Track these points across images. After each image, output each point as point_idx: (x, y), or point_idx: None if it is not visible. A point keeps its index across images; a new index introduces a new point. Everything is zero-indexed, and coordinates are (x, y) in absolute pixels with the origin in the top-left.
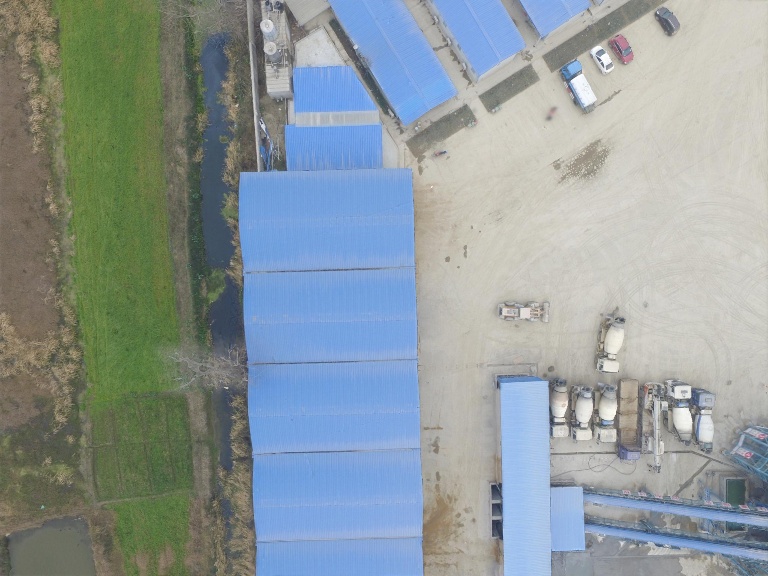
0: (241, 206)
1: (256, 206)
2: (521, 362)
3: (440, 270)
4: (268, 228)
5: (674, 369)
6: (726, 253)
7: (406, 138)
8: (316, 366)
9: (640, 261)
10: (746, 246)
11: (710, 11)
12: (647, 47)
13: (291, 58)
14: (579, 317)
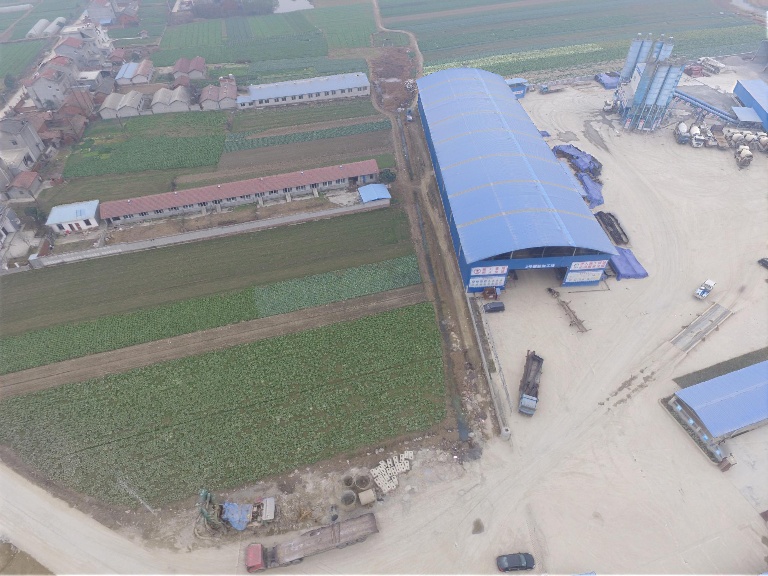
0: None
1: None
2: None
3: None
4: None
5: None
6: None
7: None
8: None
9: None
10: (670, 180)
11: None
12: None
13: None
14: (761, 170)
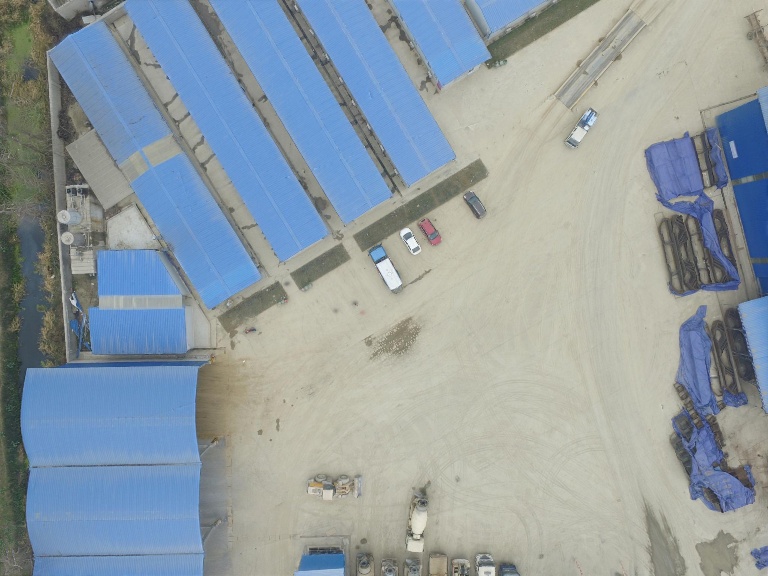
0: (24, 405)
1: (38, 406)
2: (334, 534)
3: (252, 443)
4: (50, 428)
5: (486, 542)
6: (537, 430)
7: (218, 313)
8: (102, 559)
9: (451, 436)
10: (557, 423)
11: (519, 194)
12: (457, 228)
13: (103, 234)
14: (391, 490)
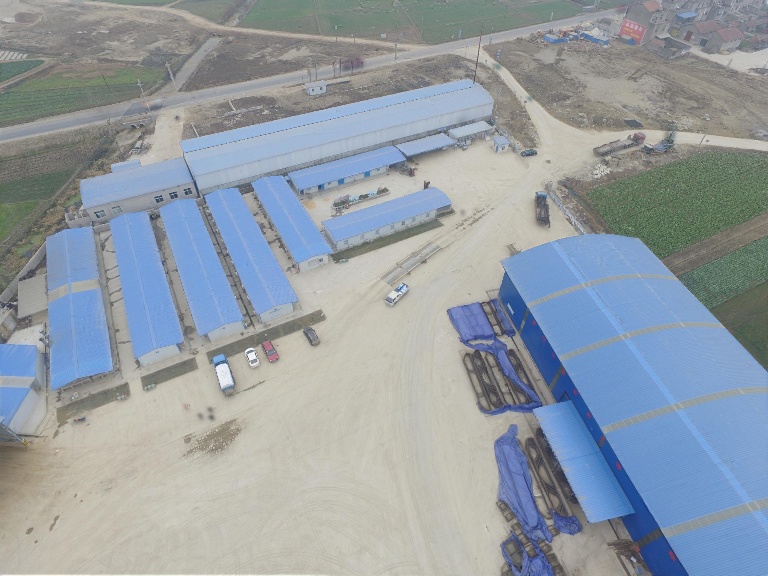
0: None
1: None
2: None
3: (13, 544)
4: None
5: None
6: (344, 549)
7: (59, 405)
8: None
9: (244, 551)
10: (367, 542)
11: (348, 332)
12: (294, 352)
13: (4, 341)
14: None
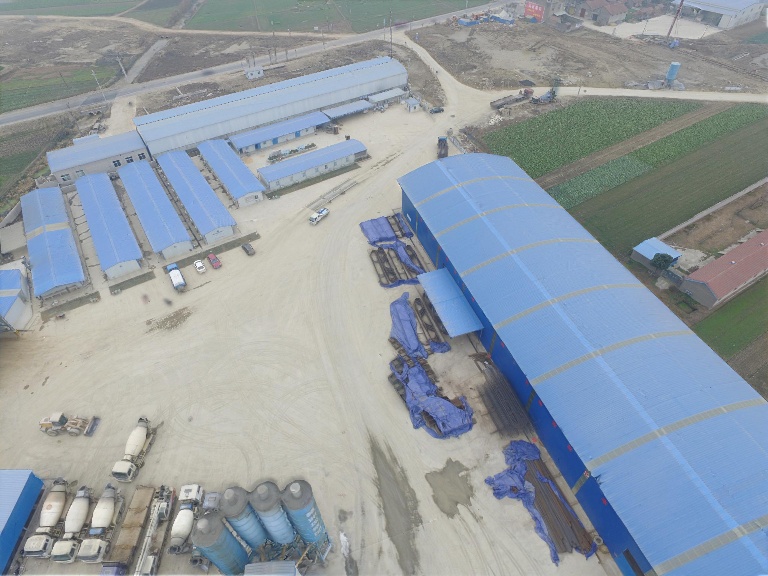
0: None
1: None
2: (46, 477)
3: (14, 396)
4: None
5: (203, 480)
6: (272, 376)
7: (43, 310)
8: None
9: (195, 384)
10: (289, 370)
11: (279, 245)
12: (234, 261)
13: None
14: (123, 432)
